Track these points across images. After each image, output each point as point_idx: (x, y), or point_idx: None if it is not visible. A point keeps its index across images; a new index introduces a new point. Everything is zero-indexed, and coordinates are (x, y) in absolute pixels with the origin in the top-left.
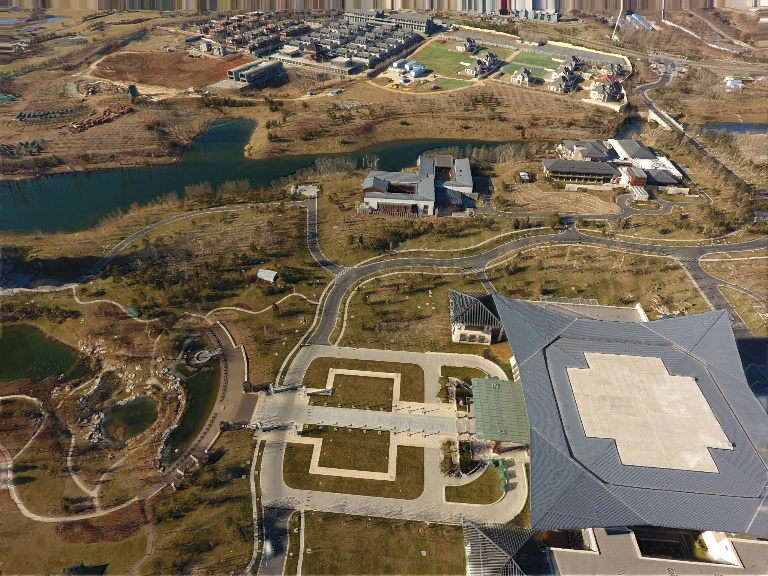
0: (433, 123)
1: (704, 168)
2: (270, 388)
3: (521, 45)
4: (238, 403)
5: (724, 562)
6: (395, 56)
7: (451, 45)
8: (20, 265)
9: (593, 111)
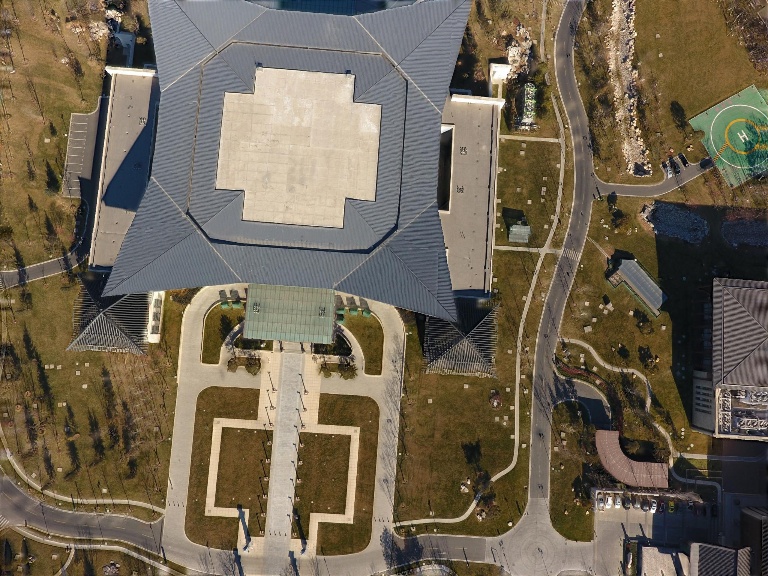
0: None
1: None
2: None
3: None
4: None
5: (443, 136)
6: None
7: None
8: None
9: None
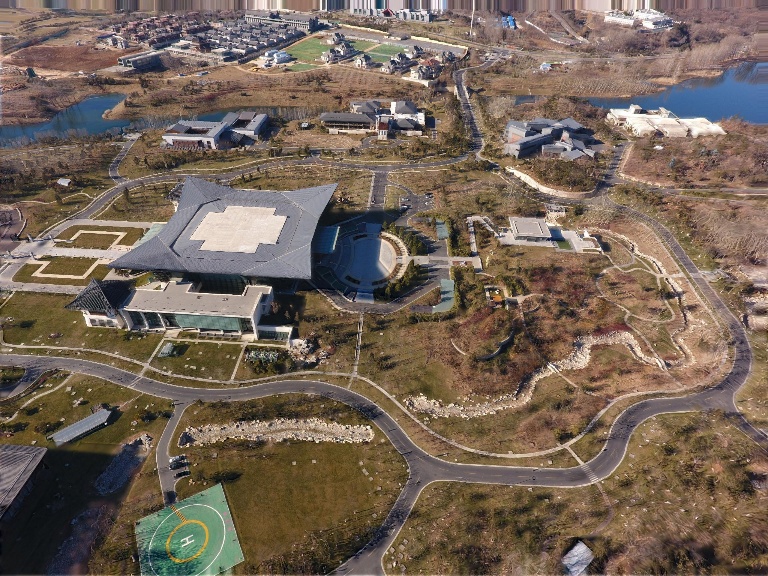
0: (268, 94)
1: None
2: (28, 237)
3: (386, 40)
4: (5, 246)
5: None
6: (270, 48)
7: (324, 40)
8: None
9: (404, 85)
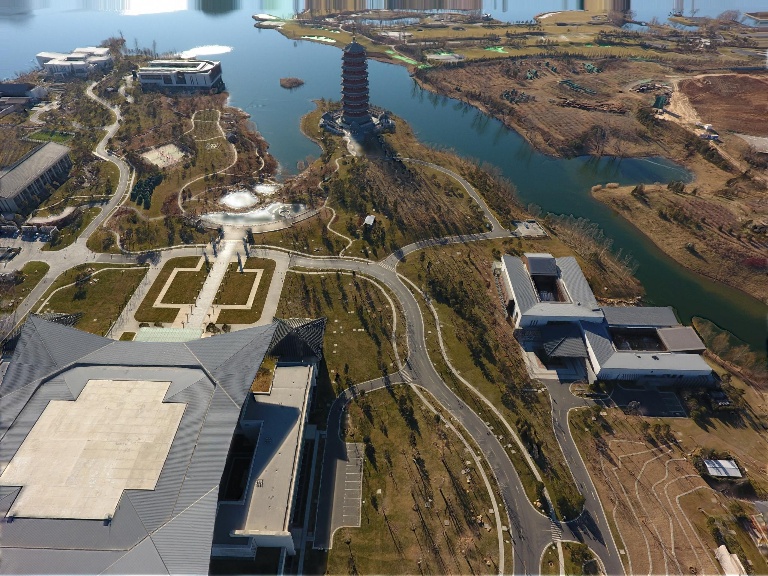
0: None
1: None
2: None
3: None
4: (240, 233)
5: None
6: None
7: None
8: (372, 134)
9: None
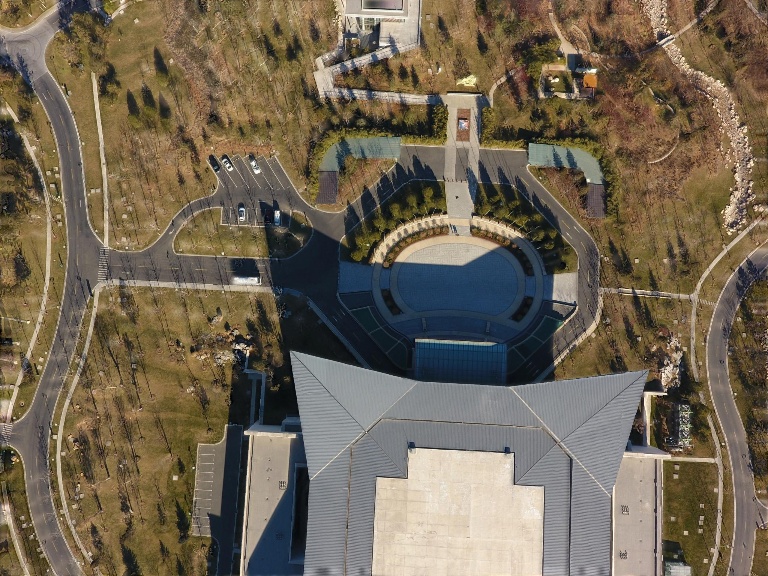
0: None
1: None
2: None
3: None
4: None
5: None
6: None
7: None
8: None
9: None
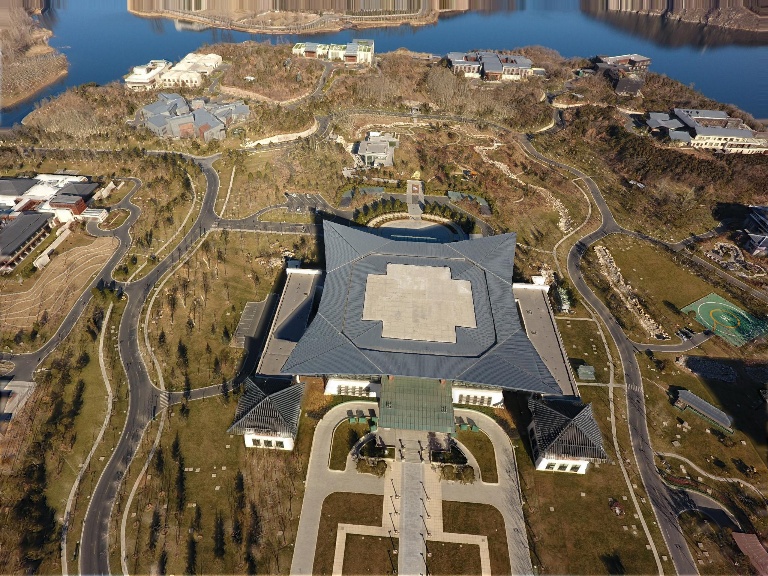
0: None
1: (77, 161)
2: None
3: None
4: None
5: None
6: None
7: None
8: None
9: None
